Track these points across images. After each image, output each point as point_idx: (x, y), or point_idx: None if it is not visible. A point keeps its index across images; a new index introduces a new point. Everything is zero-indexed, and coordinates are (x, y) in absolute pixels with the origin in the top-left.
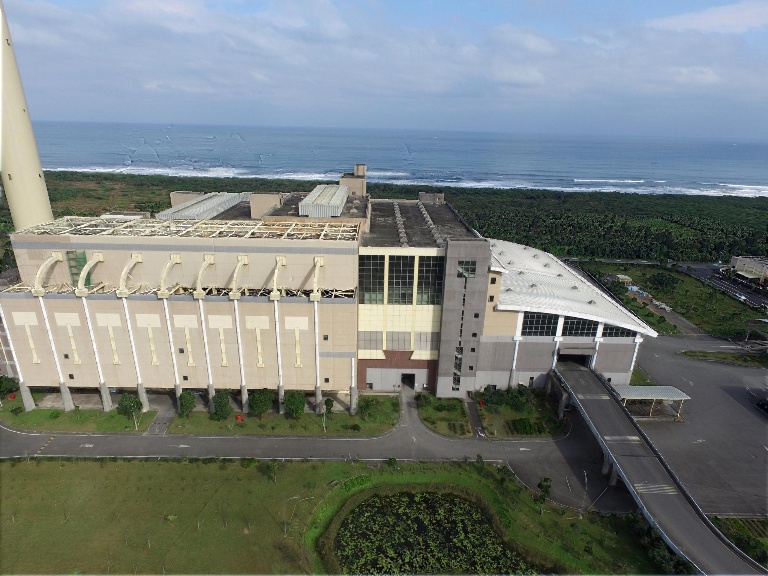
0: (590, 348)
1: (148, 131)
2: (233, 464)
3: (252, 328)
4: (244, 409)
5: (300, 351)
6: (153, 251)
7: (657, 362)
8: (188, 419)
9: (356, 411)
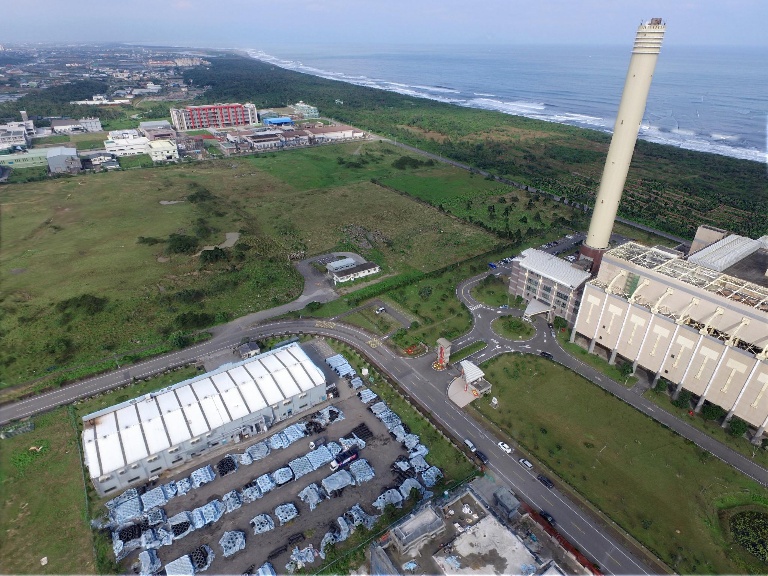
0: None
1: (680, 105)
2: (679, 437)
3: (730, 367)
4: (696, 409)
5: (761, 398)
6: (683, 291)
7: None
8: (657, 395)
9: None
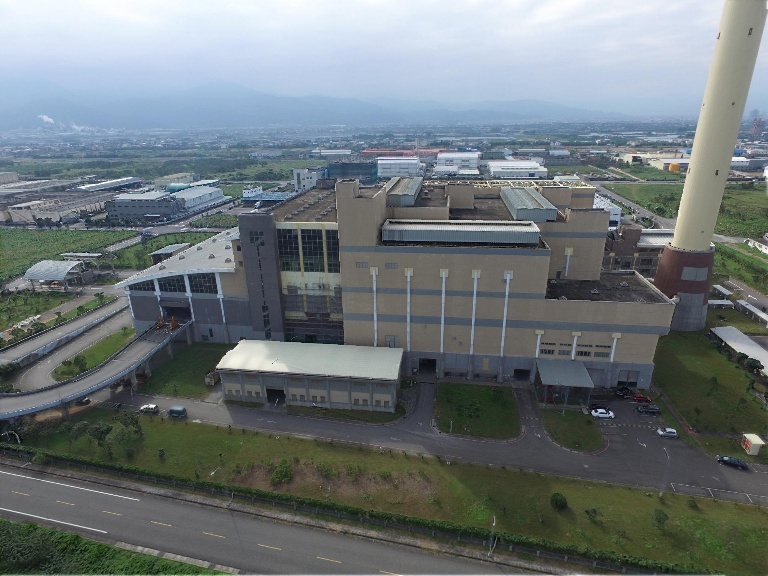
0: None
1: None
2: None
3: None
4: None
5: None
6: None
7: None
8: None
9: None
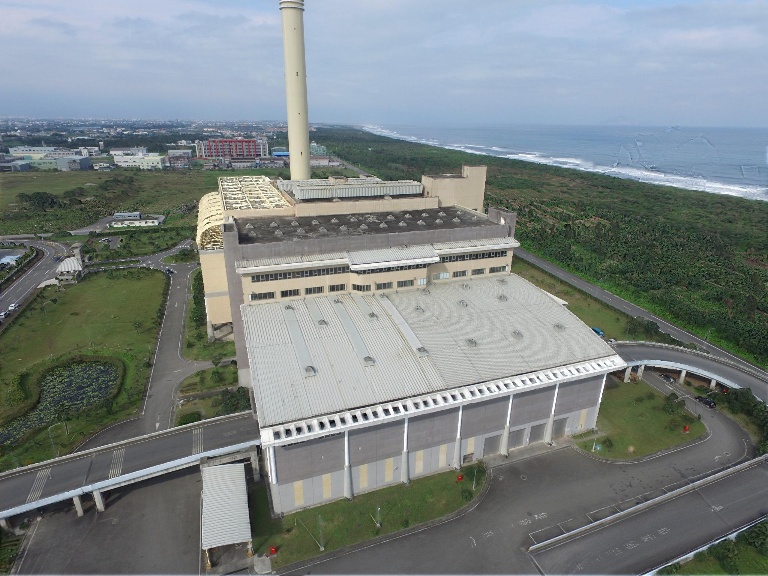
0: None
1: (624, 134)
2: None
3: None
4: None
5: None
6: None
7: None
8: None
9: (211, 342)
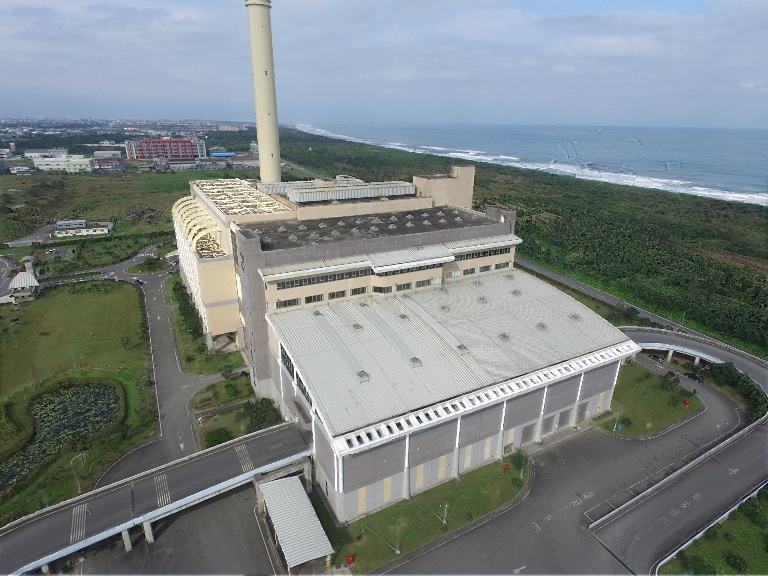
0: (308, 419)
1: (561, 133)
2: None
3: None
4: None
5: (198, 289)
6: (201, 201)
7: (488, 568)
8: None
9: (212, 354)
